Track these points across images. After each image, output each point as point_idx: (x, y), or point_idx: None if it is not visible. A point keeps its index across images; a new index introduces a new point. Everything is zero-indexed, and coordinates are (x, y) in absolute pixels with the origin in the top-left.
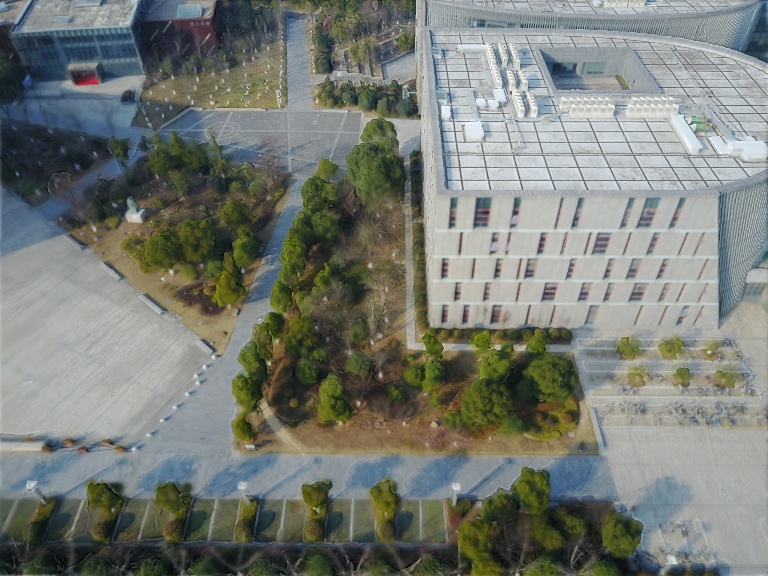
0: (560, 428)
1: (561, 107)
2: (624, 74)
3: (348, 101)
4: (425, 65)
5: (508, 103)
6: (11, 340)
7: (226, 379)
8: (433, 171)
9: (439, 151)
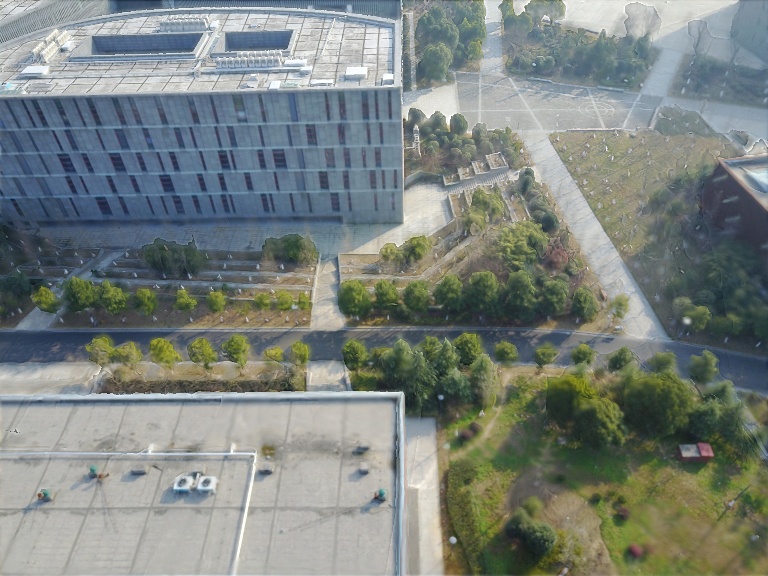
0: None
1: None
2: None
3: None
4: None
5: None
6: (609, 8)
7: (495, 4)
8: None
9: None
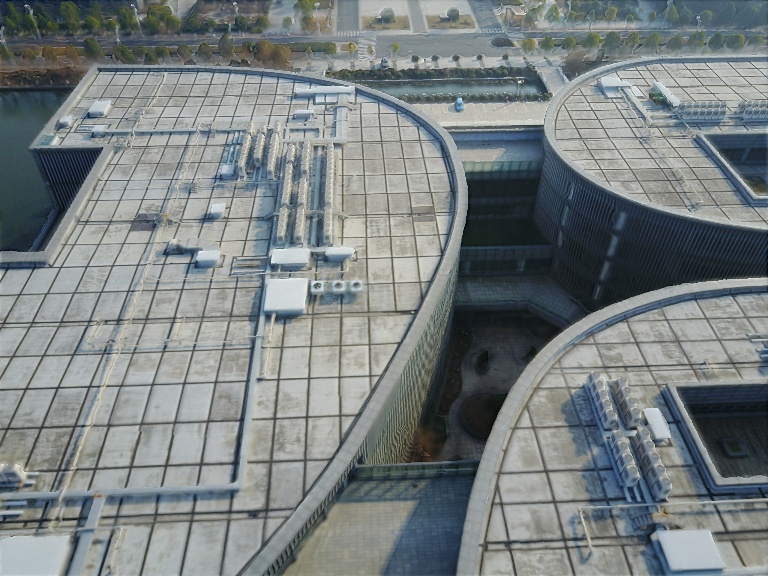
0: None
1: None
2: None
3: None
4: None
5: None
6: None
7: None
8: None
9: None
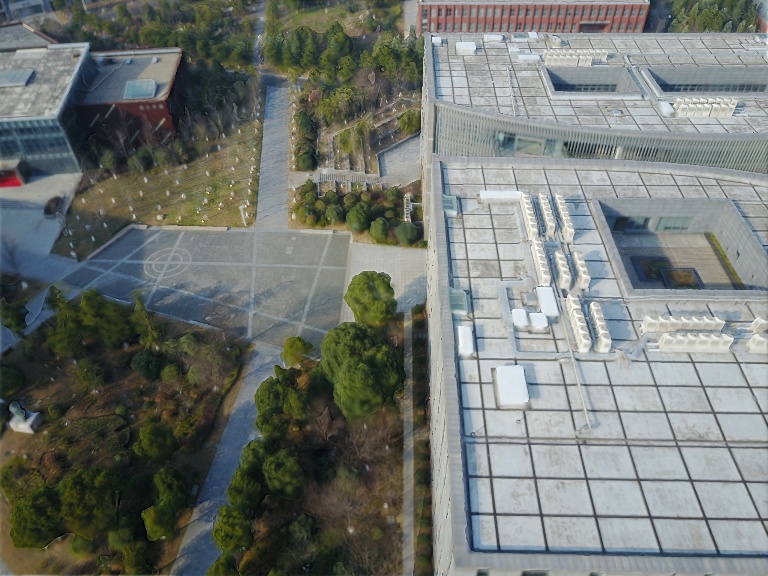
0: None
1: (645, 329)
2: (719, 234)
3: (333, 218)
4: (433, 223)
5: (561, 318)
6: None
7: None
8: (446, 468)
9: (456, 442)
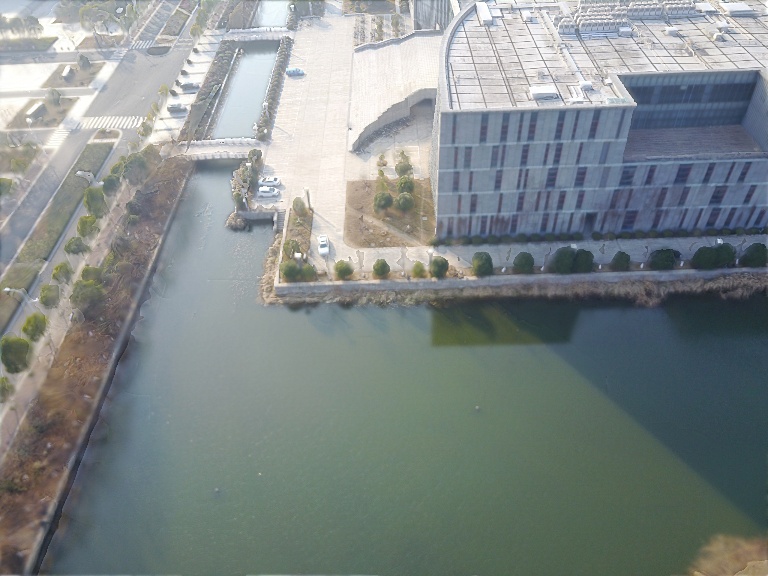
0: (353, 8)
1: None
2: None
3: None
4: None
5: None
6: None
7: None
8: None
9: None
